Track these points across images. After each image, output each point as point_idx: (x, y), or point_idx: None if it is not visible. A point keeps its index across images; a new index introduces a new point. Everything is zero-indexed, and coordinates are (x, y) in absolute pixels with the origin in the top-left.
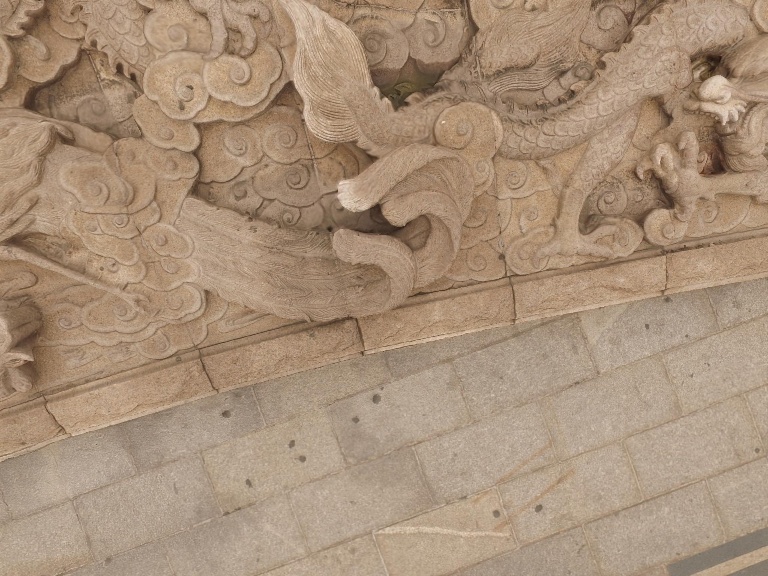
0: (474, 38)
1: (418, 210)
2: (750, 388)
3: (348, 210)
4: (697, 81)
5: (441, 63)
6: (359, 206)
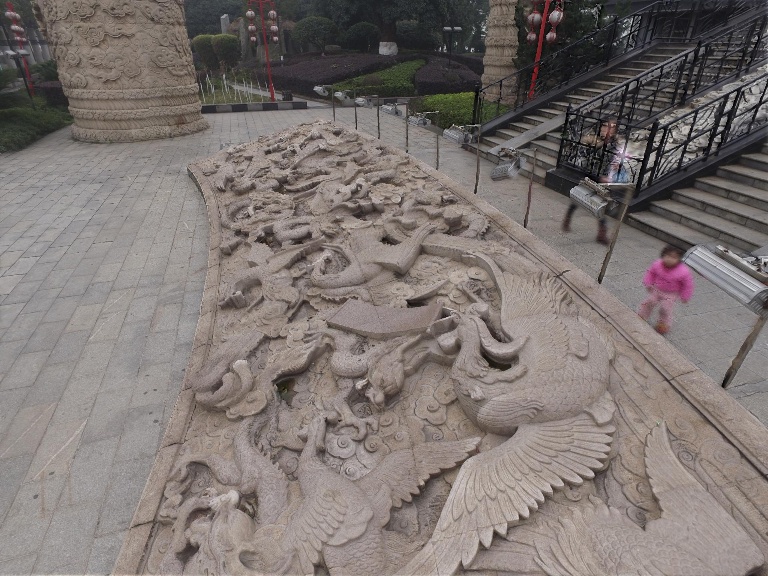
0: (295, 407)
1: None
2: None
3: None
4: (243, 501)
5: None
6: None
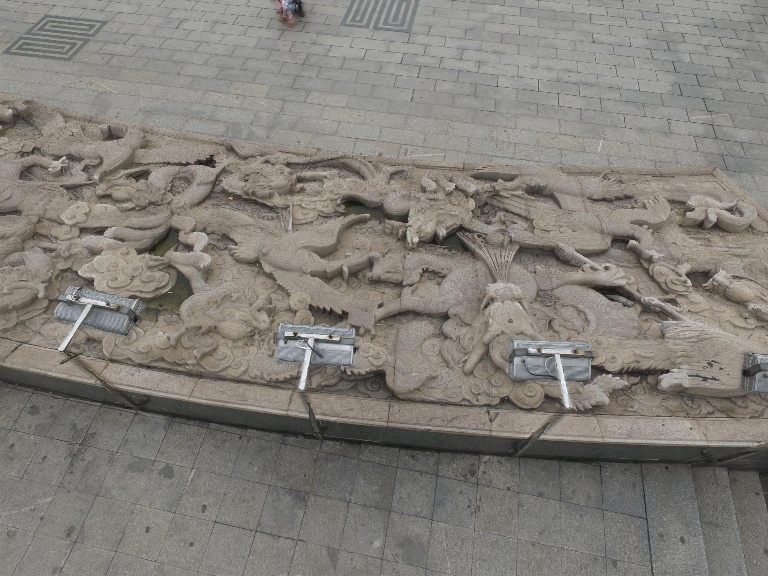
0: None
1: (1, 105)
2: (7, 80)
3: None
4: None
5: None
6: (9, 109)
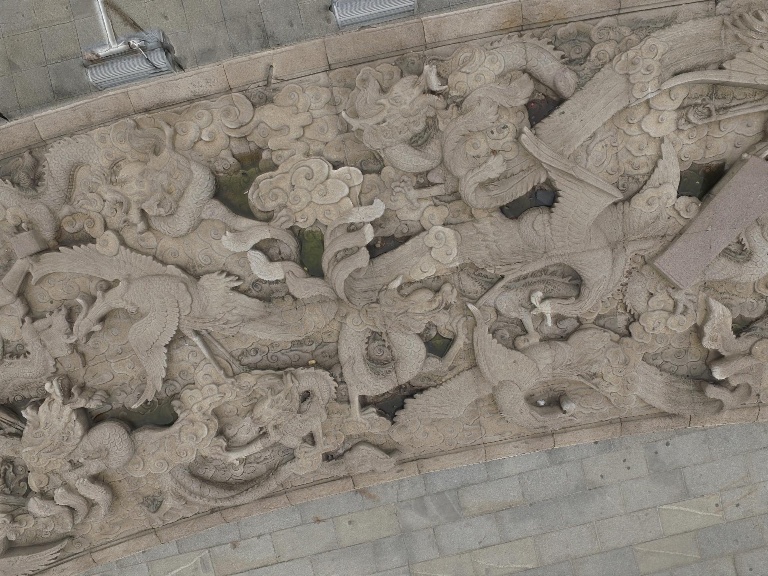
0: None
1: (743, 381)
2: None
3: (698, 369)
4: None
5: (752, 318)
6: (721, 378)
